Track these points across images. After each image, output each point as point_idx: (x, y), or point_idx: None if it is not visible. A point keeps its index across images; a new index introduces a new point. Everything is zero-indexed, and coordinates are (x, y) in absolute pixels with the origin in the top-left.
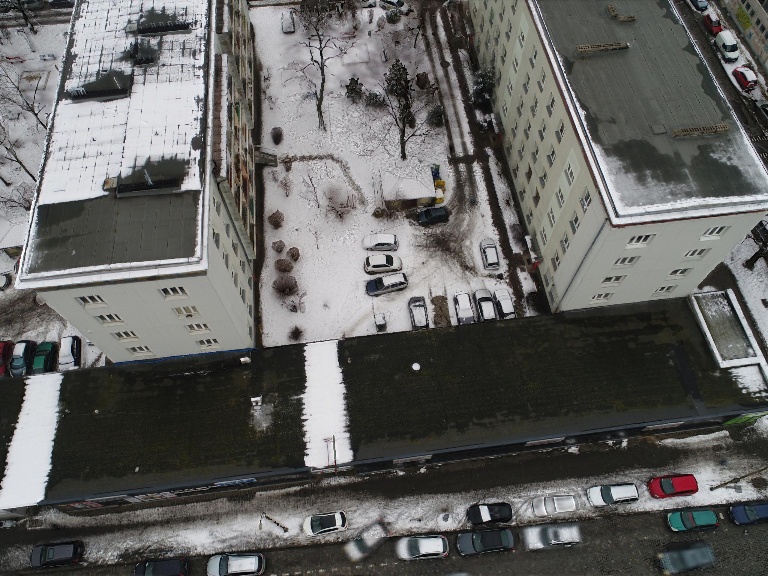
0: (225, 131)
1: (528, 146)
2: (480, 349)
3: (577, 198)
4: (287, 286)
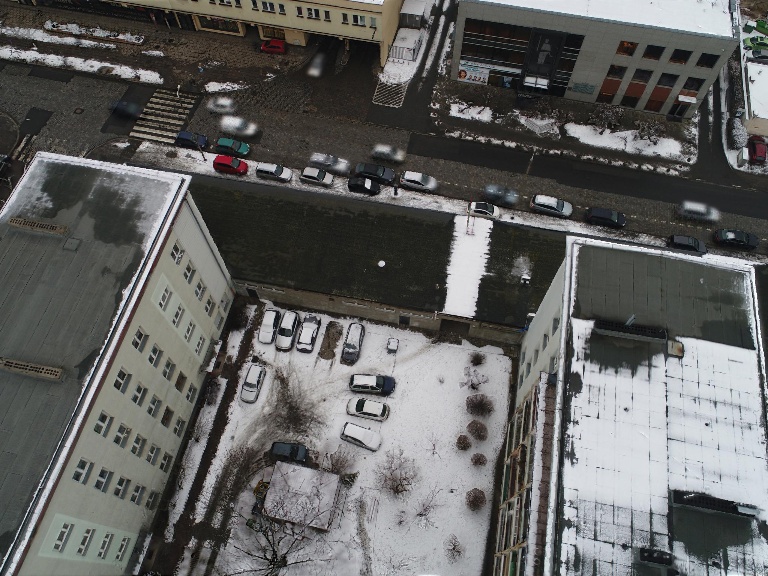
0: (538, 442)
1: (151, 433)
2: (320, 268)
3: (178, 271)
4: (478, 408)
